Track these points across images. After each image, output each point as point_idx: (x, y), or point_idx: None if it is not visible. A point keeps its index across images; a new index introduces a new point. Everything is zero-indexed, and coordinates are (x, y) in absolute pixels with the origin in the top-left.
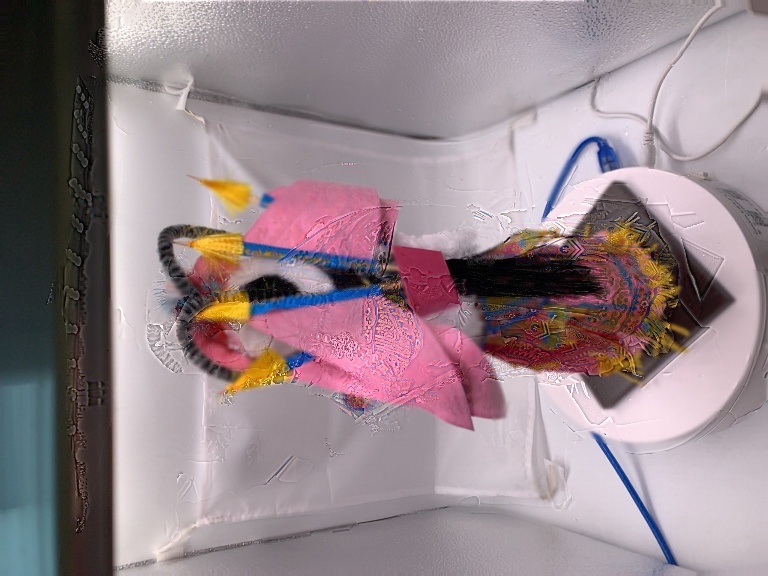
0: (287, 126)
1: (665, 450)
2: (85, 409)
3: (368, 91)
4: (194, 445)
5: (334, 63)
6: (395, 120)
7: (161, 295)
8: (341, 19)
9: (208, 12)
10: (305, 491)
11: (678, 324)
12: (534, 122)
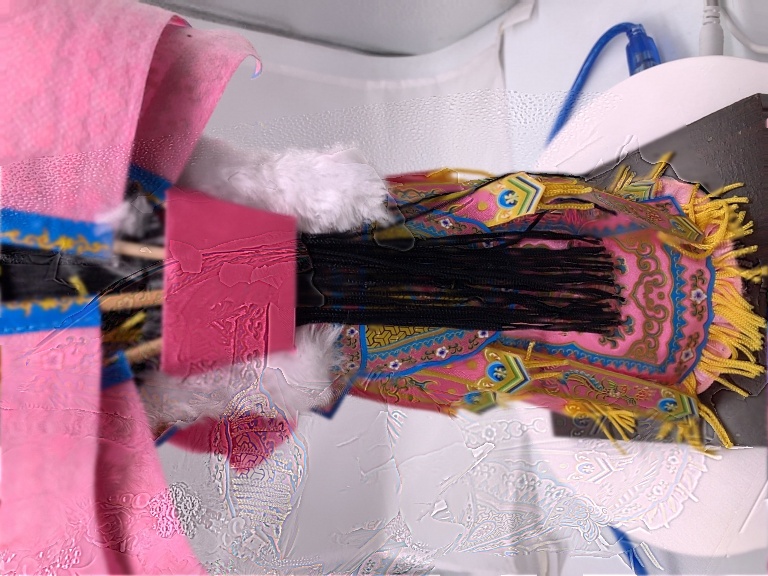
0: None
1: None
2: None
3: (278, 225)
4: None
5: (233, 199)
6: None
7: None
8: (232, 148)
9: (76, 165)
10: None
11: (758, 406)
12: None
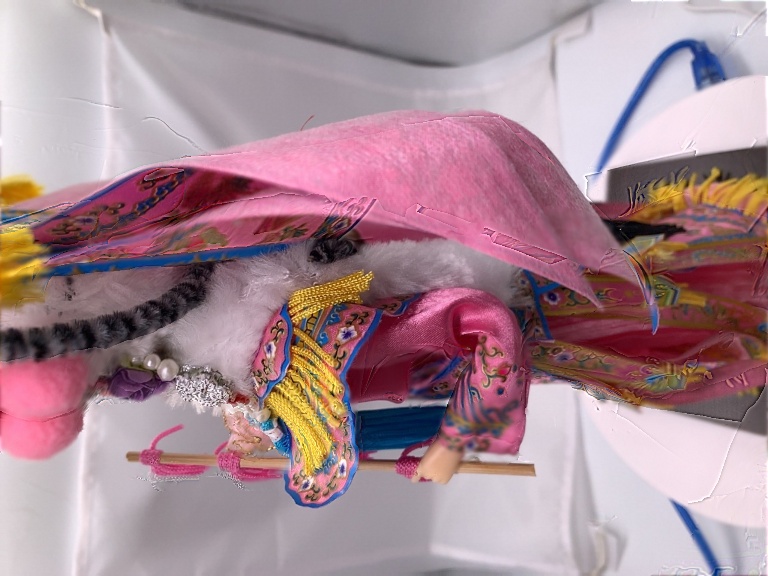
0: None
1: None
2: None
3: None
4: None
5: None
6: None
7: None
8: None
9: None
10: None
11: None
12: None
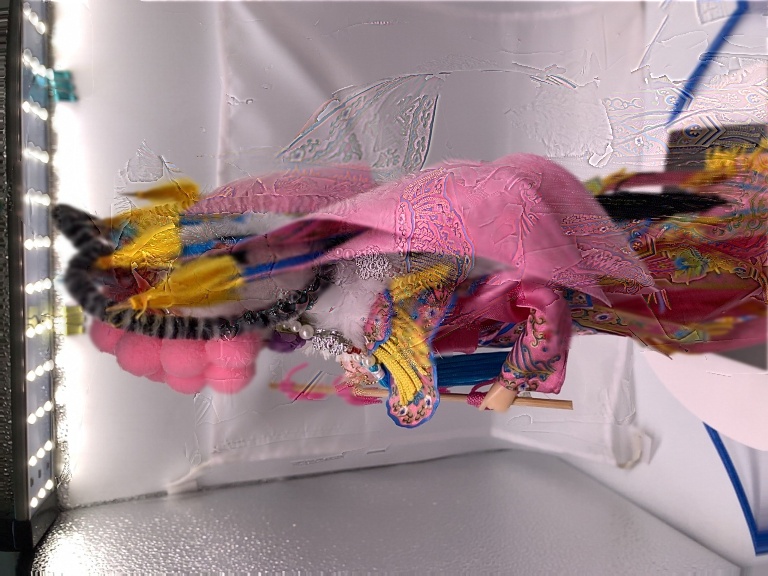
0: None
1: (765, 374)
2: (64, 339)
3: None
4: (210, 362)
5: None
6: None
7: (122, 206)
8: None
9: None
10: (336, 410)
11: None
12: None
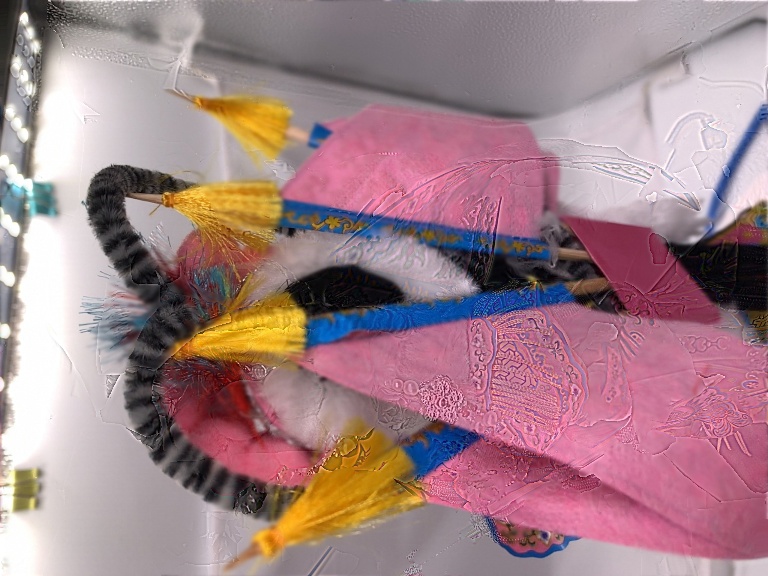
0: (307, 107)
1: None
2: (8, 518)
3: (410, 59)
4: (193, 541)
5: (366, 23)
6: (445, 96)
7: (118, 319)
8: None
9: None
10: None
11: None
12: (618, 96)
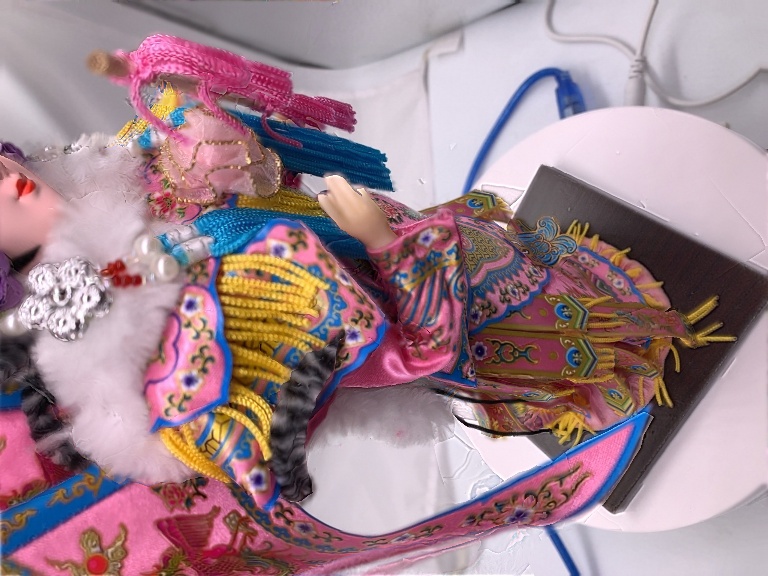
0: None
1: (762, 148)
2: None
3: None
4: None
5: None
6: None
7: None
8: None
9: None
10: None
11: (545, 191)
12: None
